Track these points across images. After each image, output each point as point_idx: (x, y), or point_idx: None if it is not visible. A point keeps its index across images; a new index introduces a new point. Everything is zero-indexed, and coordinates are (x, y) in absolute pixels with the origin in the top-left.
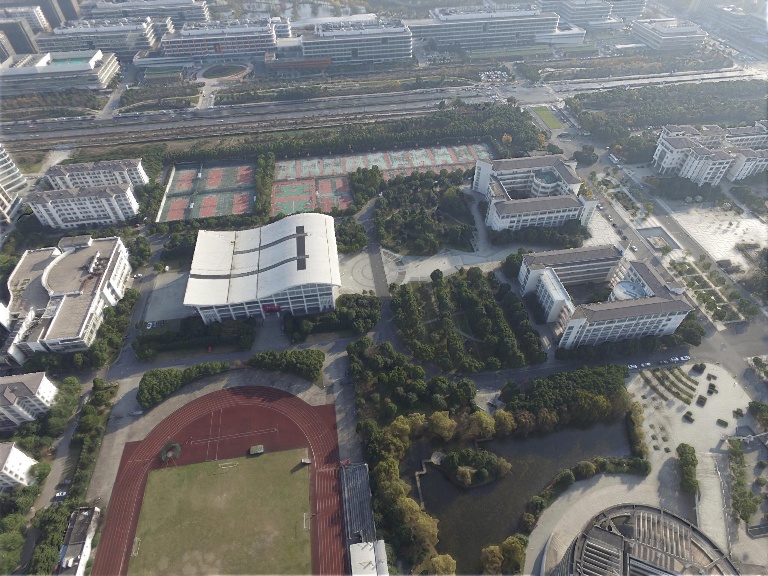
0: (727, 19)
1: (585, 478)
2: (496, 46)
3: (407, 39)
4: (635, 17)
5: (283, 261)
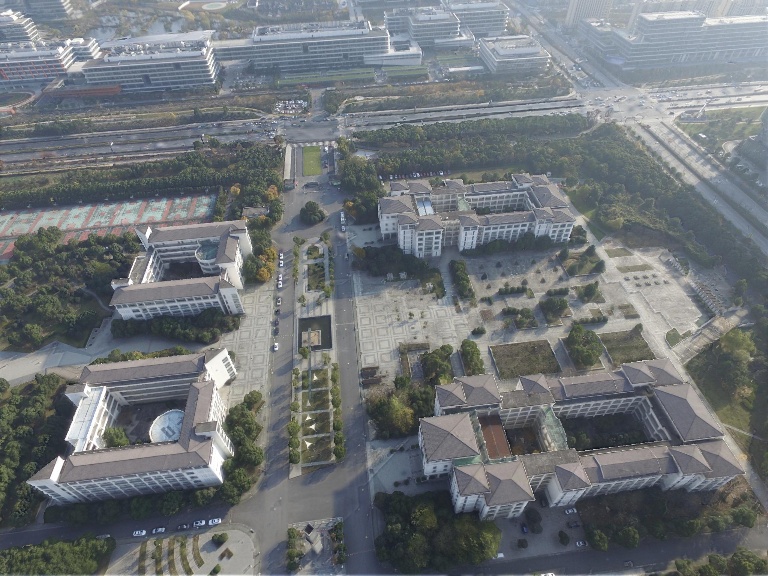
0: (593, 35)
1: None
2: (322, 68)
3: (203, 64)
4: (499, 32)
5: None
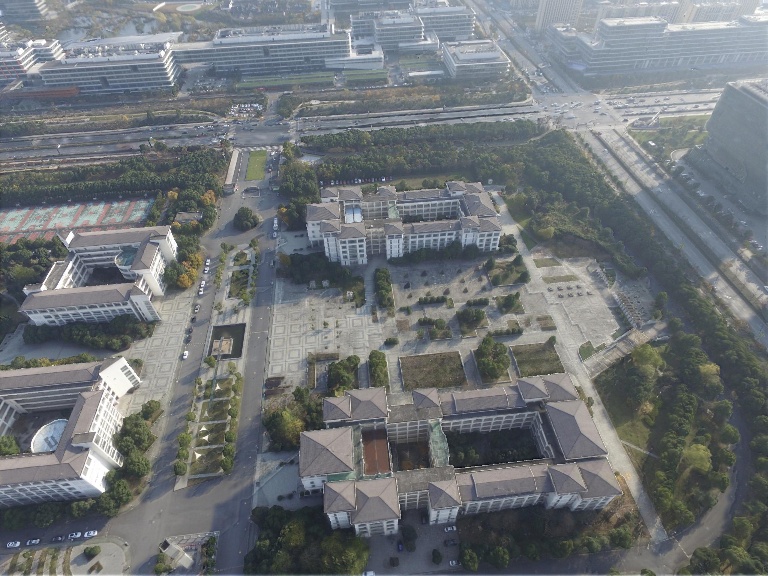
0: (558, 40)
1: None
2: (284, 72)
3: (160, 67)
4: (466, 36)
5: None
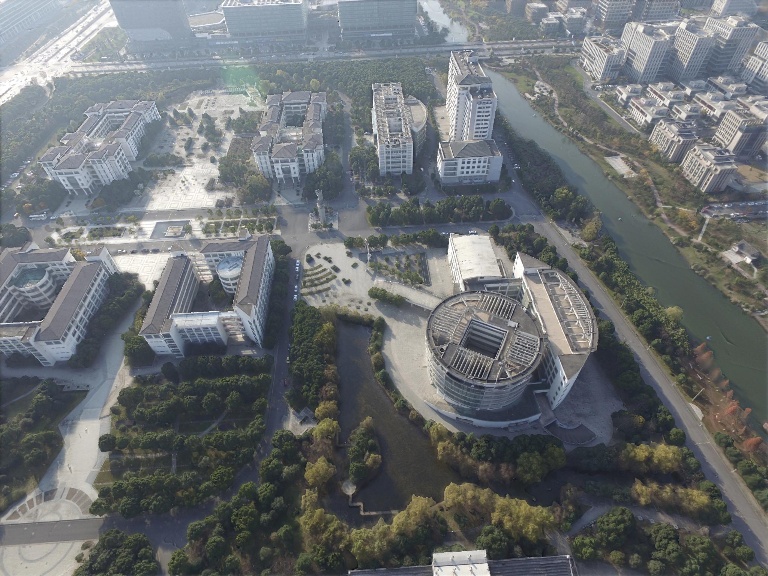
0: None
1: (384, 364)
2: None
3: None
4: None
5: None
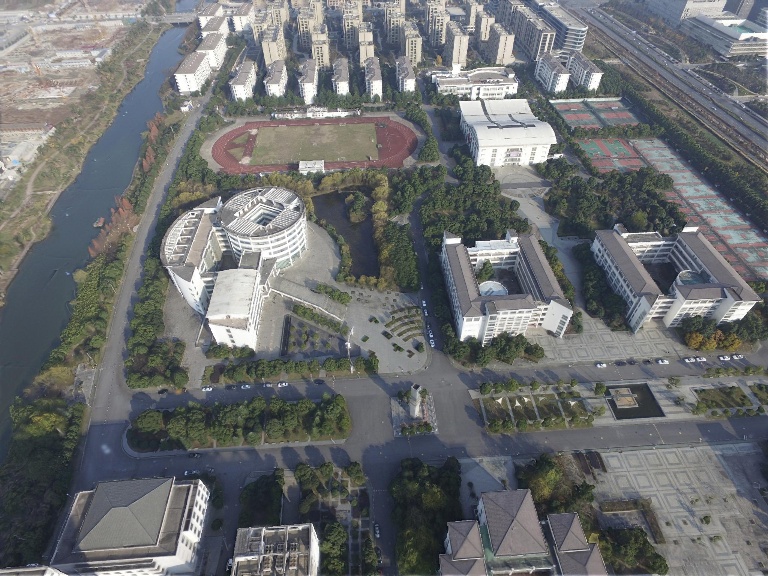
0: None
1: None
2: None
3: None
4: None
5: (498, 123)
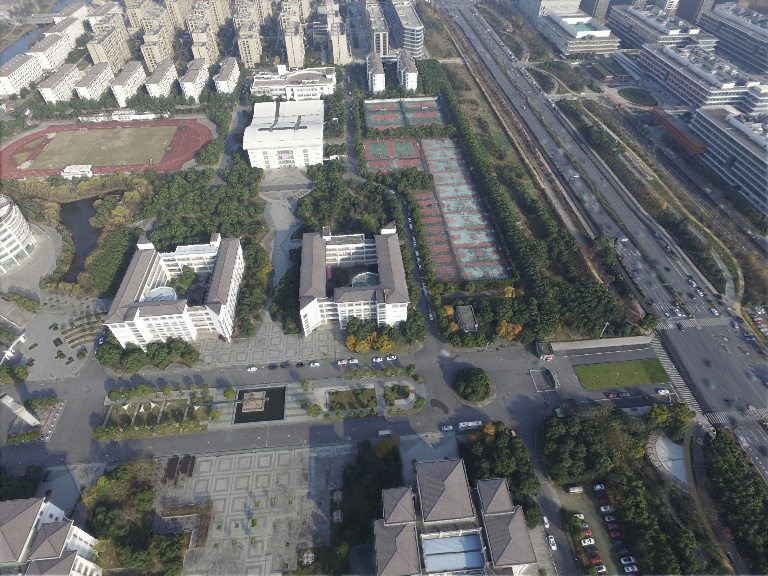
0: None
1: None
2: None
3: None
4: None
5: None
